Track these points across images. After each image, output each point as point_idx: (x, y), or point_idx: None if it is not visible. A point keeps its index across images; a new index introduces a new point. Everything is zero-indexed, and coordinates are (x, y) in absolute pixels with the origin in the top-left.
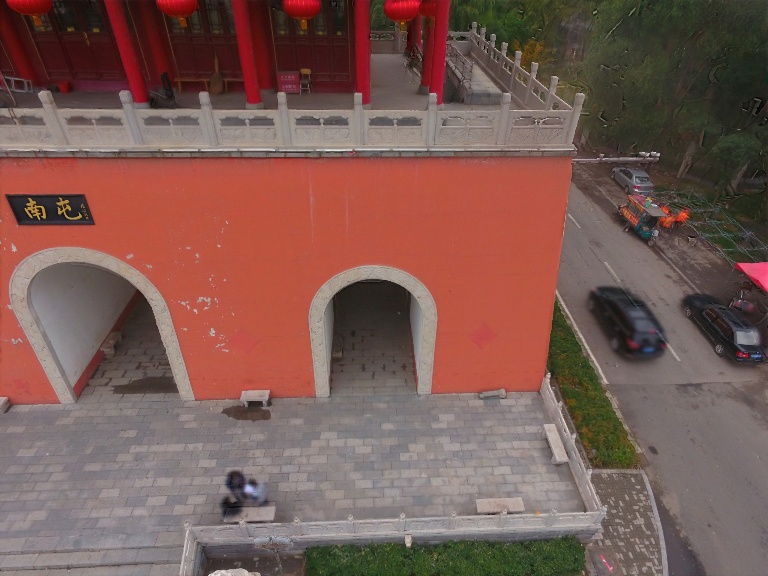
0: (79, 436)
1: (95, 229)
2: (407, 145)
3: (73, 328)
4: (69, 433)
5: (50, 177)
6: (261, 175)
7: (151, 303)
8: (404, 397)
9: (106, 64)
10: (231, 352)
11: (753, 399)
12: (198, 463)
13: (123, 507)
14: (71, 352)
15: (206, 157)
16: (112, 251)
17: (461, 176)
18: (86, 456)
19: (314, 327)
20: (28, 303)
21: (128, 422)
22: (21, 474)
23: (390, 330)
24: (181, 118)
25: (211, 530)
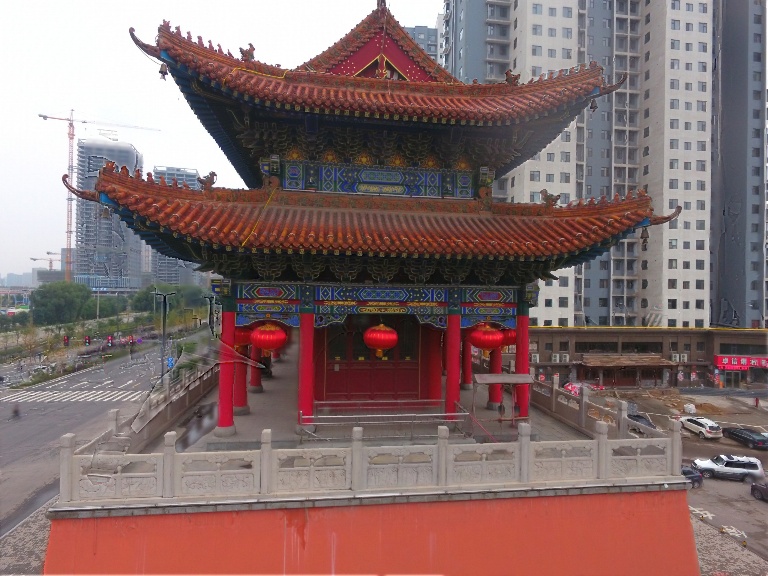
0: None
1: None
2: None
3: None
4: None
5: None
6: None
7: None
8: None
9: None
10: None
11: None
12: None
13: None
14: None
15: None
16: None
17: None
18: None
19: None
20: None
21: None
22: None
23: None
24: None
25: None
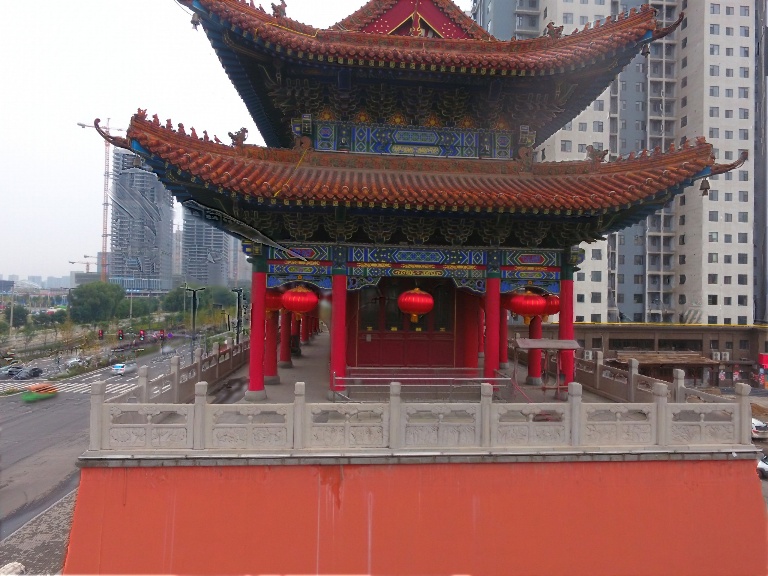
0: None
1: None
2: None
3: None
4: None
5: None
6: None
7: None
8: None
9: None
10: None
11: None
12: None
13: None
14: None
15: None
16: None
17: None
18: None
19: None
20: None
21: None
22: None
23: None
24: None
25: None
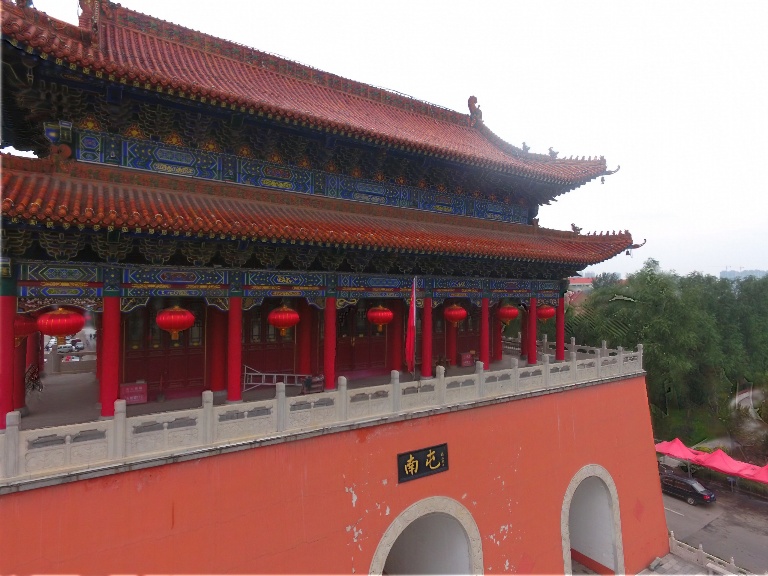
0: None
1: (447, 474)
2: (592, 378)
3: None
4: None
5: (430, 432)
6: (537, 408)
7: (472, 544)
8: None
9: (358, 358)
10: None
11: (737, 522)
12: None
13: None
14: None
15: (515, 400)
16: (454, 494)
17: (613, 393)
18: None
19: (564, 534)
20: None
21: None
22: None
23: None
24: (502, 376)
25: None
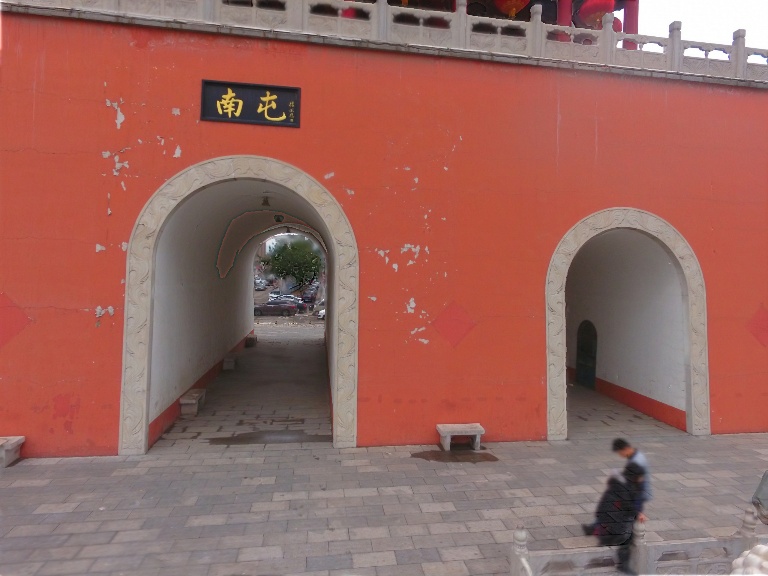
0: (163, 486)
1: (297, 134)
2: None
3: (170, 336)
4: (142, 483)
5: (267, 65)
6: (507, 85)
7: (337, 250)
8: (677, 437)
9: None
10: (431, 344)
11: None
12: (420, 507)
13: (304, 572)
14: (161, 366)
15: (454, 57)
16: (308, 167)
17: (710, 104)
18: (186, 507)
19: (552, 301)
20: (156, 241)
21: (252, 469)
22: (45, 536)
23: (577, 395)
24: (432, 20)
25: (565, 567)
